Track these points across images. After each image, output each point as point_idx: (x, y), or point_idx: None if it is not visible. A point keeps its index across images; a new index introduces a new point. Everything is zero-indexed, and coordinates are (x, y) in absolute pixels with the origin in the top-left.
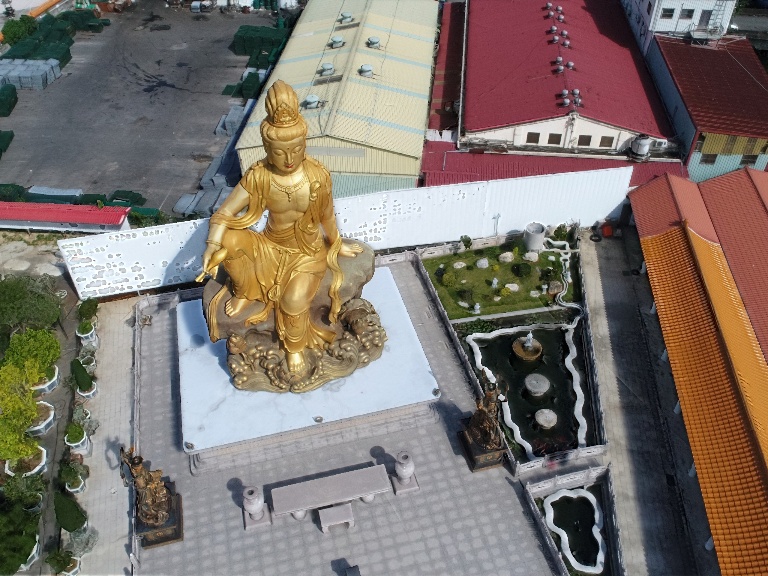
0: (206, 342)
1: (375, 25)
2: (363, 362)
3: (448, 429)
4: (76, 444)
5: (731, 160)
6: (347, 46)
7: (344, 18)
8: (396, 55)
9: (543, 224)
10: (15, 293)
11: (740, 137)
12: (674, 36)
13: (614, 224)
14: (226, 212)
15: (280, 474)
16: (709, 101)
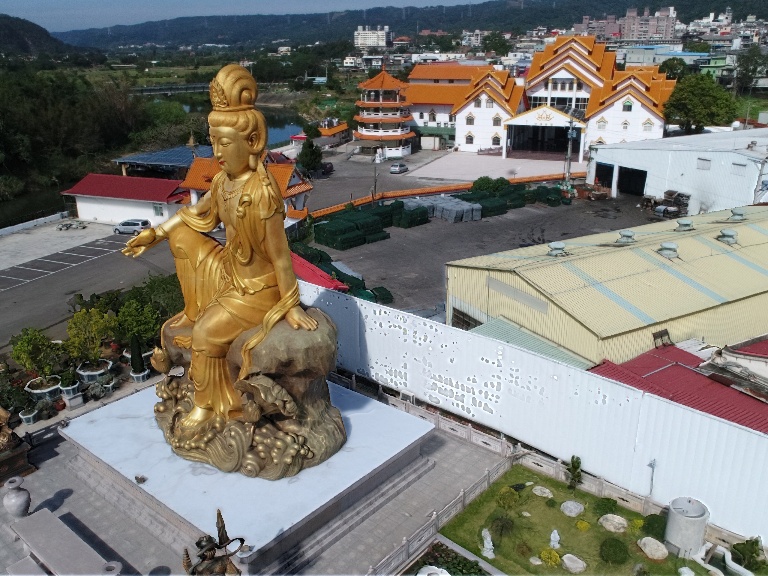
0: None
1: (765, 229)
2: None
3: None
4: (62, 388)
5: None
6: (690, 231)
7: (733, 215)
8: (747, 257)
9: (743, 528)
10: (178, 282)
11: None
12: None
13: None
14: (193, 207)
15: (90, 515)
16: None
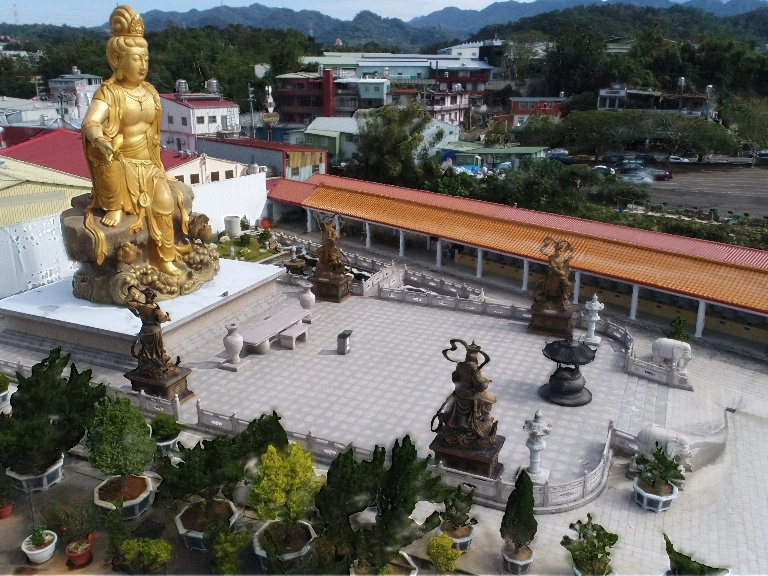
0: (59, 305)
1: None
2: (215, 270)
3: (298, 299)
4: (4, 393)
5: (307, 171)
6: None
7: None
8: None
9: None
10: None
11: (307, 153)
12: (210, 136)
13: (268, 219)
14: None
15: (218, 349)
16: (271, 146)
